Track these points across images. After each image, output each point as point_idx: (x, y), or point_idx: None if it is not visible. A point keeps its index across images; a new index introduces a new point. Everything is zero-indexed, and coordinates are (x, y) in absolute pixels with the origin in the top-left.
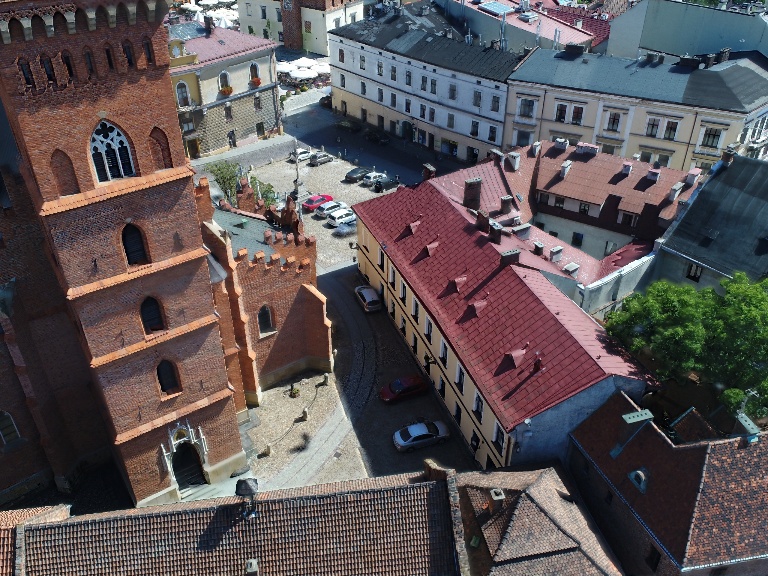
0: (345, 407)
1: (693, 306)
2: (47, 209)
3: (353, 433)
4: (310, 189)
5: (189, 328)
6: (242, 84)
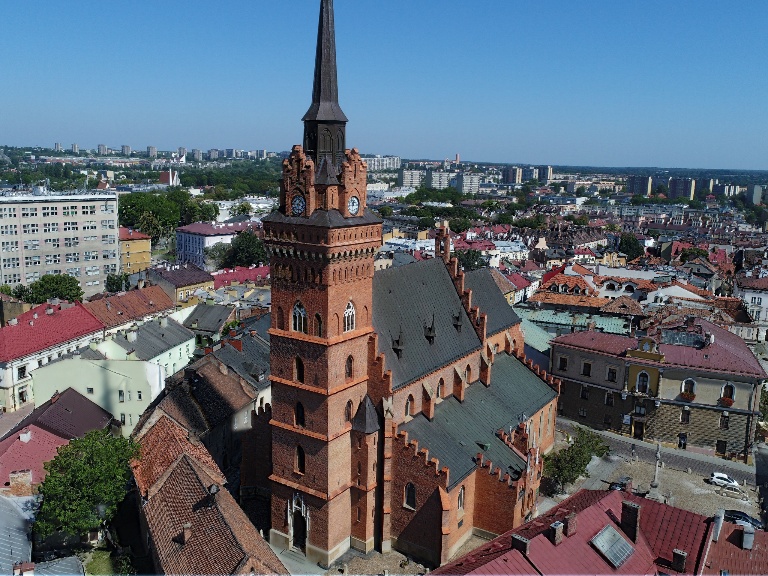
0: None
1: None
2: (270, 331)
3: None
4: (675, 501)
5: (313, 435)
6: (710, 397)
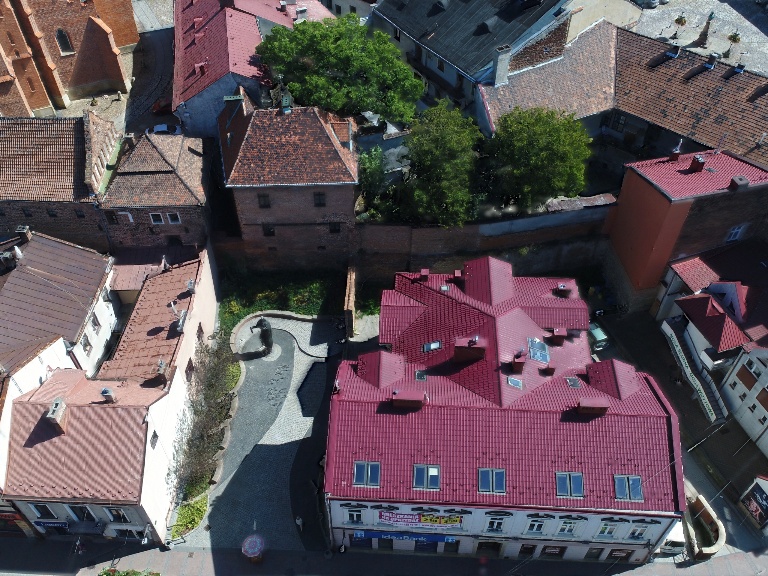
0: (126, 115)
1: (300, 31)
2: None
3: (124, 130)
4: None
5: None
6: None
